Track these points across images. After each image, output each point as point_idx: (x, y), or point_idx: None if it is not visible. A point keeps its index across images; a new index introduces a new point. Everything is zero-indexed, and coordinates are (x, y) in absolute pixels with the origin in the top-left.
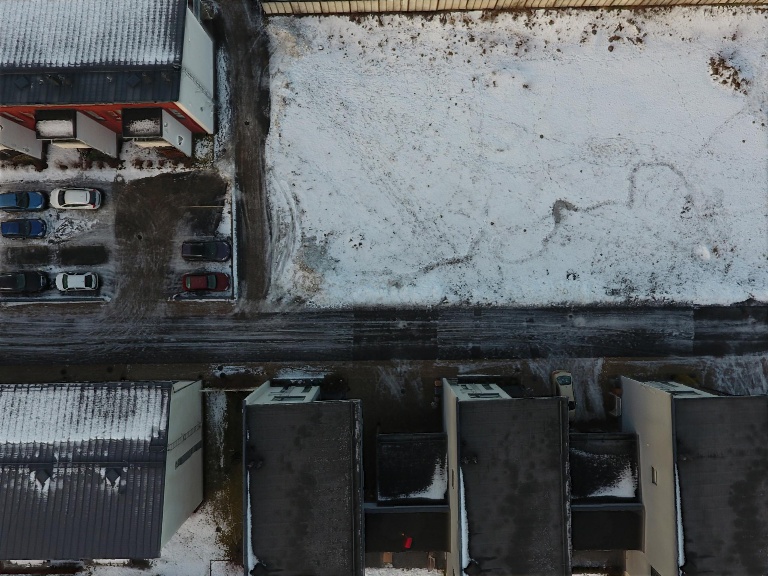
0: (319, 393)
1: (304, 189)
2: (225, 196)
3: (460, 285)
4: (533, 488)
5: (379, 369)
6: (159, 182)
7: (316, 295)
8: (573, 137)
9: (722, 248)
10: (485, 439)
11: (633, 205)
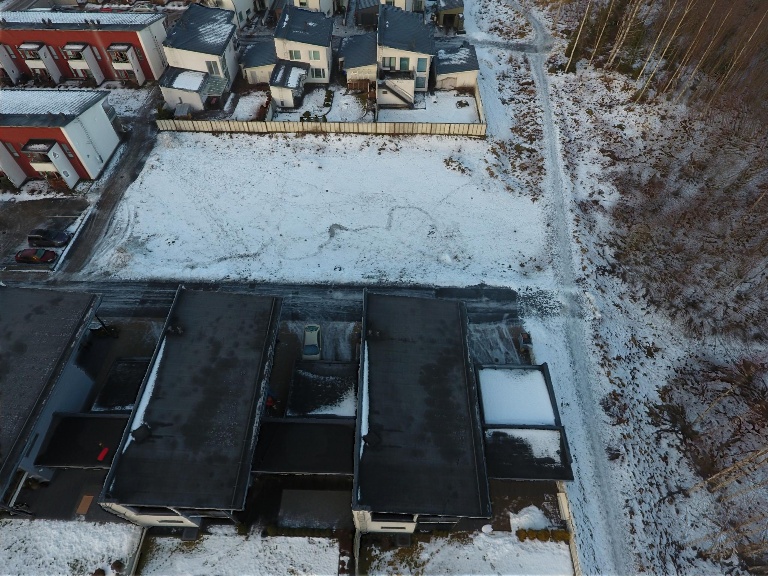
0: (87, 335)
1: (145, 210)
2: (84, 211)
3: (244, 270)
4: (231, 363)
5: (152, 324)
6: (40, 203)
7: (122, 270)
8: (349, 192)
9: (461, 256)
10: (197, 319)
11: (391, 229)
